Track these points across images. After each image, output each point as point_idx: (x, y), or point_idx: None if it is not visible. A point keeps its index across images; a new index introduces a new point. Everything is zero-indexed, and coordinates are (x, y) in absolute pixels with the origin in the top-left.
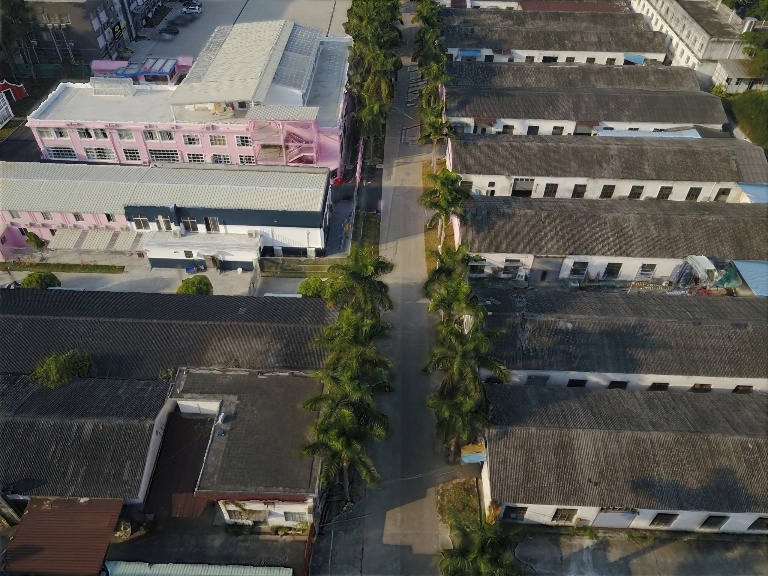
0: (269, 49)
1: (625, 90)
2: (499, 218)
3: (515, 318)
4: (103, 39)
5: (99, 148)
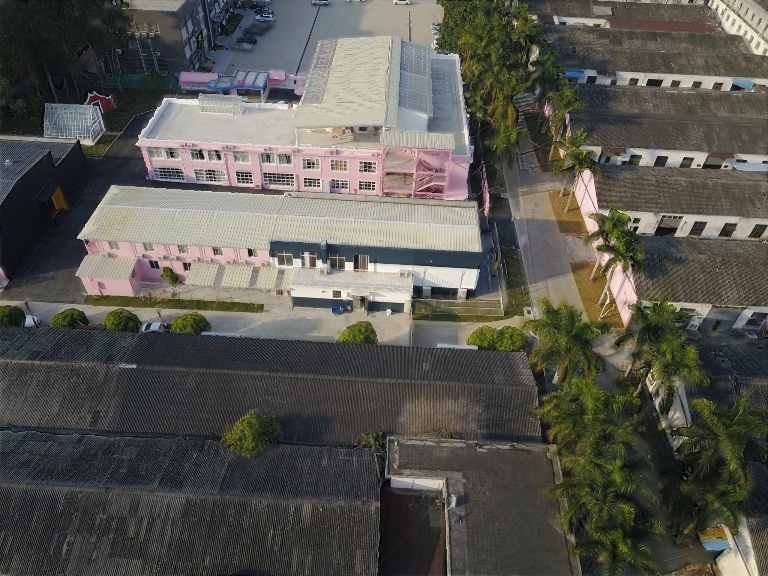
0: (385, 68)
1: (754, 120)
2: (672, 263)
3: (728, 382)
4: (189, 49)
5: (210, 170)
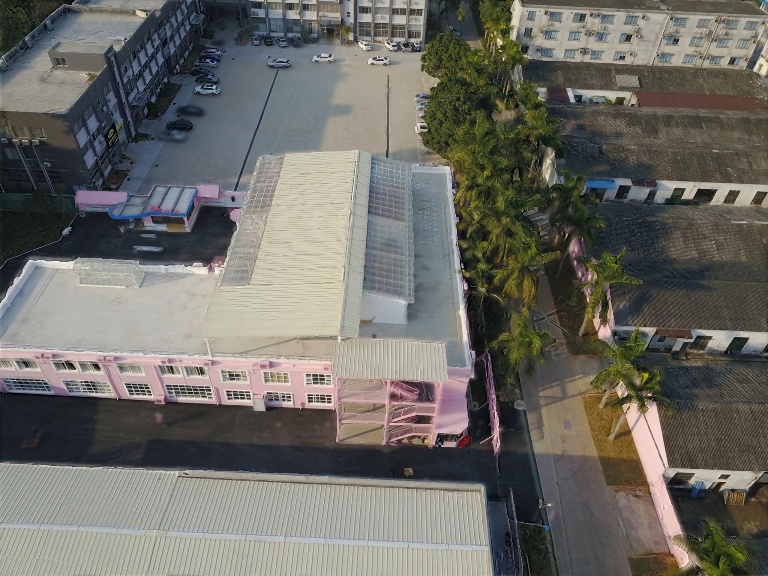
0: (346, 214)
1: None
2: None
3: None
4: (92, 154)
5: (87, 381)
